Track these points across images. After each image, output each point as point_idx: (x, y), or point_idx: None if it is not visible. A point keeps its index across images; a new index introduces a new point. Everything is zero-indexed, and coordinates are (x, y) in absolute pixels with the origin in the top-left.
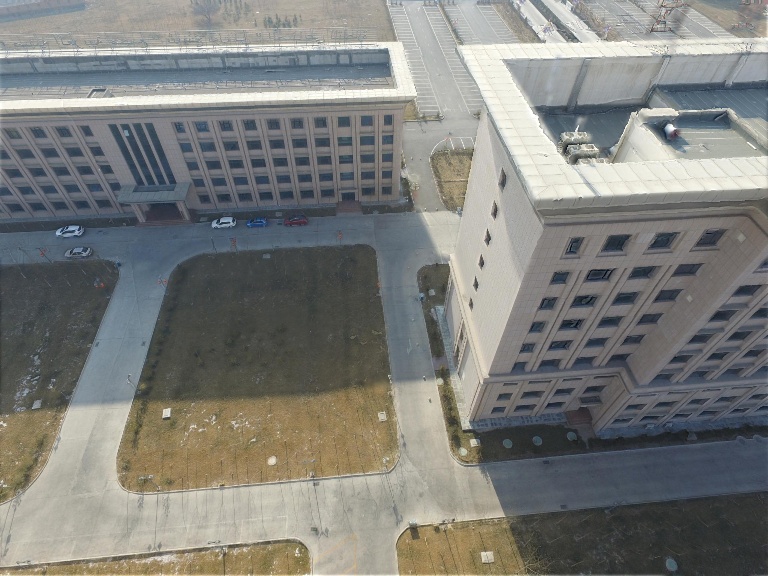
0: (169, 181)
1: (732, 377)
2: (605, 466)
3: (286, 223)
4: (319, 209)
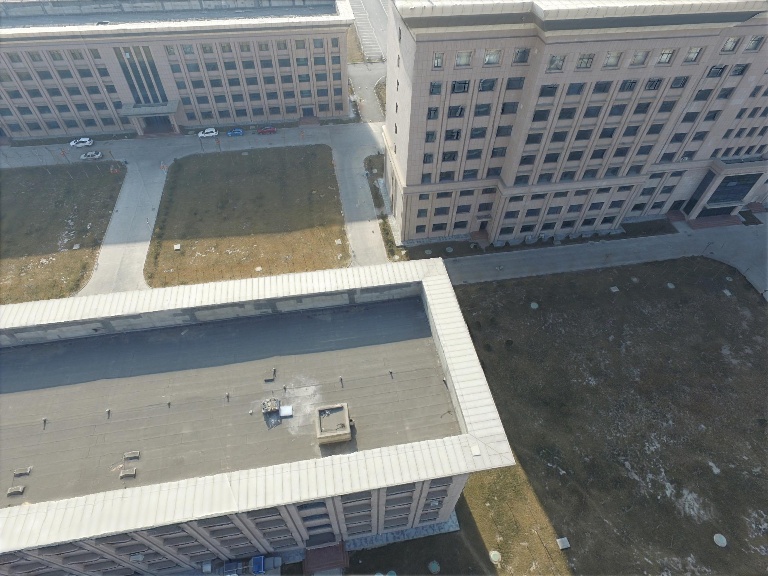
0: (162, 100)
1: (569, 181)
2: (496, 260)
3: (259, 132)
4: (285, 123)
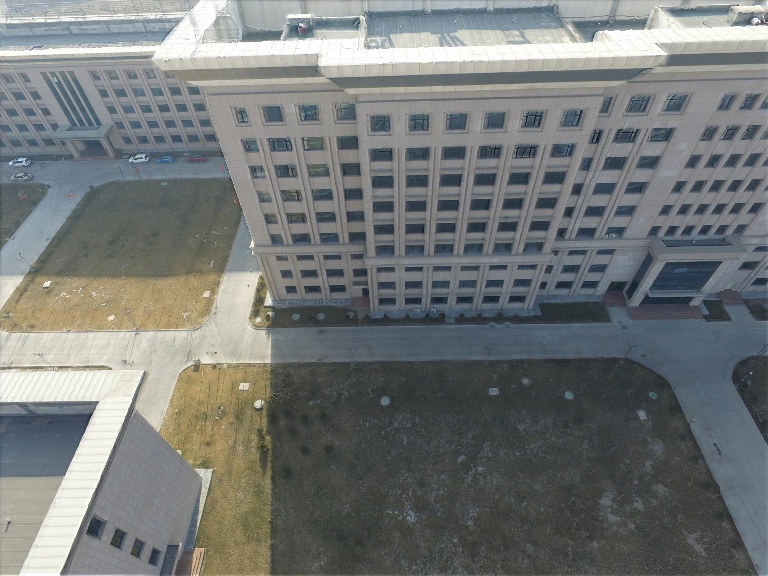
0: (96, 123)
1: (447, 254)
2: (367, 336)
3: (188, 160)
4: (220, 151)
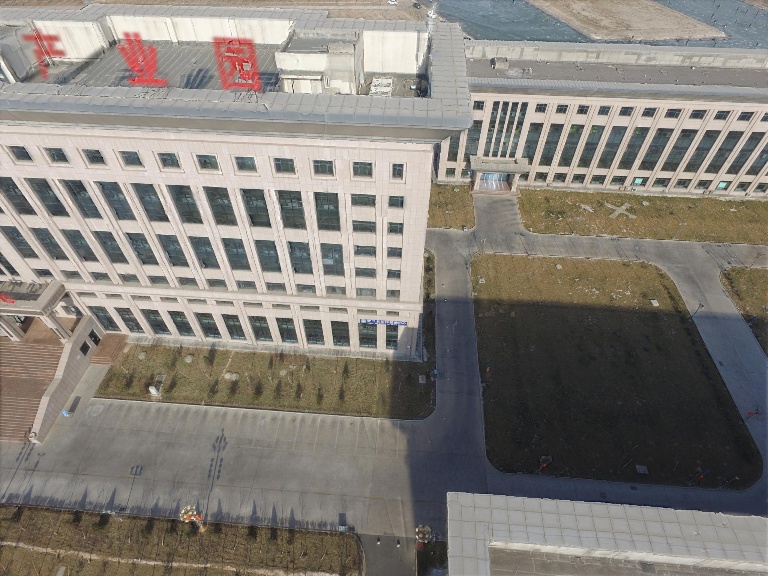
0: None
1: None
2: None
3: None
4: None
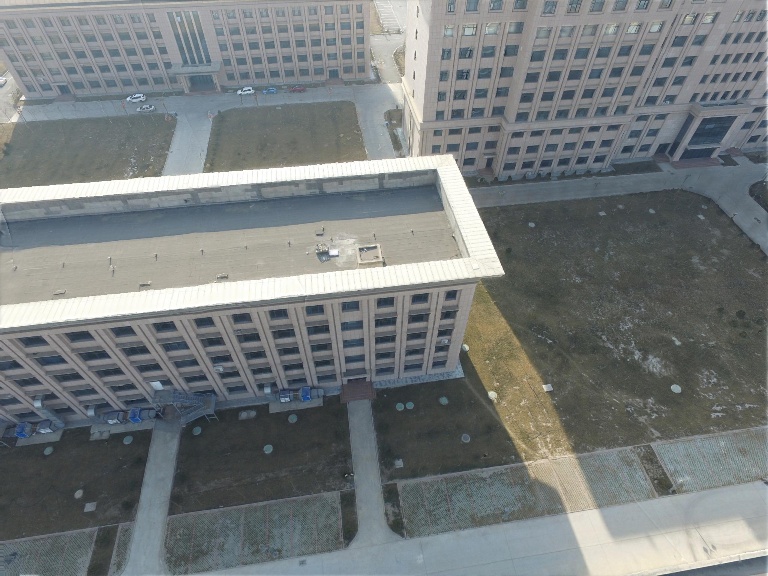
0: (206, 61)
1: (564, 119)
2: None
3: (290, 90)
4: (313, 84)
